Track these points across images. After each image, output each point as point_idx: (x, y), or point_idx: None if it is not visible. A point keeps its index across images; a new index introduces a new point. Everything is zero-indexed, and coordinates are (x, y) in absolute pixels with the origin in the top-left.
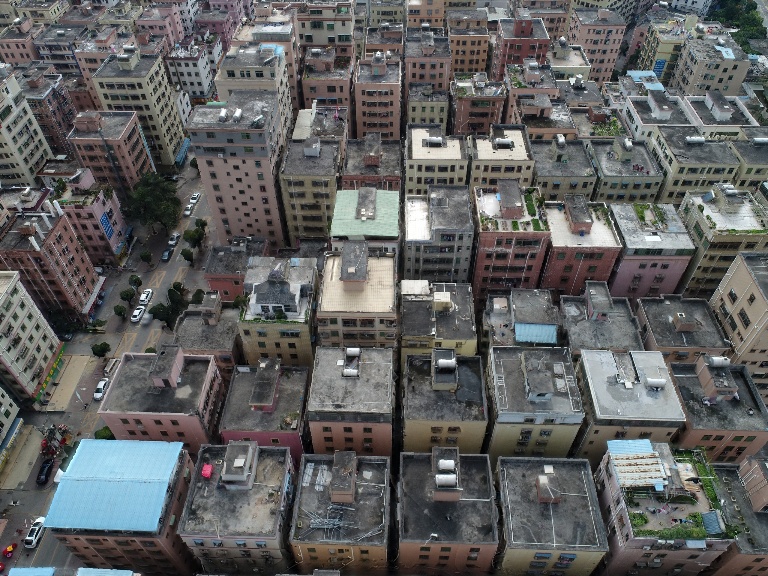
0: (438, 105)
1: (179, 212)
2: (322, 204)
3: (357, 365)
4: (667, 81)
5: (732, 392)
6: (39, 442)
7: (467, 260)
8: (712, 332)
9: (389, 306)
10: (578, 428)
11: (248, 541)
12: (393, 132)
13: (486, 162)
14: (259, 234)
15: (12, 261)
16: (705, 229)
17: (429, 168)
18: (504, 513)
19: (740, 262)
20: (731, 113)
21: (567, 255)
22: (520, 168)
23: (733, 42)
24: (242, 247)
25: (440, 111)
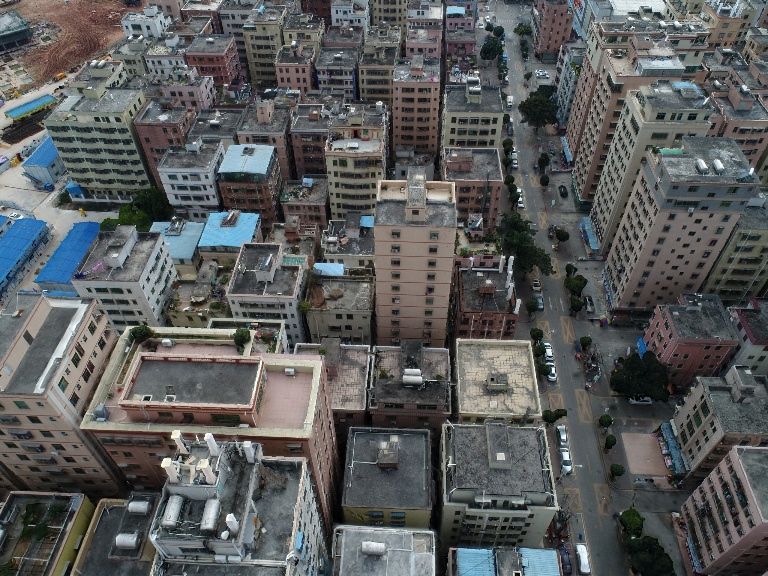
0: None
1: None
2: (765, 258)
3: None
4: None
5: None
6: None
7: None
8: None
9: None
10: None
11: None
12: None
13: None
14: (674, 287)
15: (480, 323)
16: None
17: None
18: None
19: None
20: None
21: None
22: None
23: None
24: (700, 307)
25: None
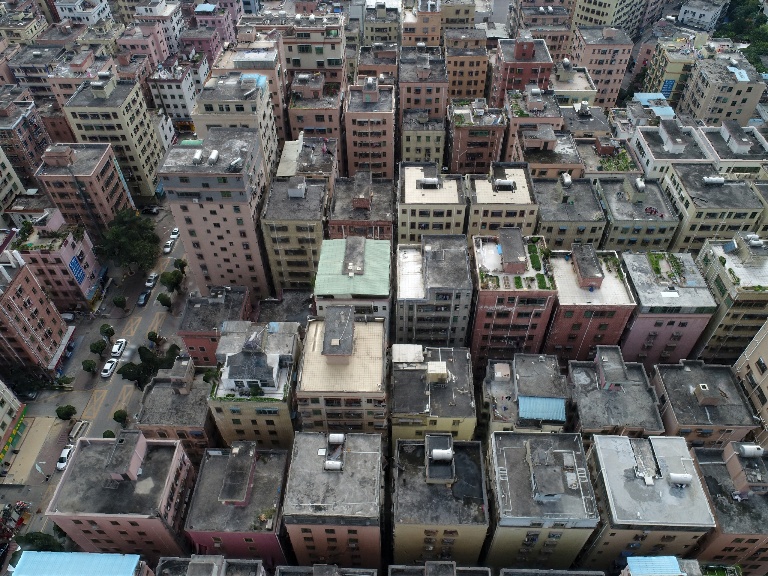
0: (434, 134)
1: (157, 251)
2: (308, 249)
3: (341, 454)
4: (676, 102)
5: (766, 487)
6: None
7: (465, 319)
8: (738, 405)
9: (377, 384)
10: (592, 531)
11: None
12: (386, 162)
13: (486, 207)
14: (241, 280)
15: None
16: (728, 285)
17: (423, 213)
18: None
19: None
20: (750, 146)
21: (575, 313)
22: (523, 213)
23: (746, 62)
24: (220, 299)
25: (436, 140)
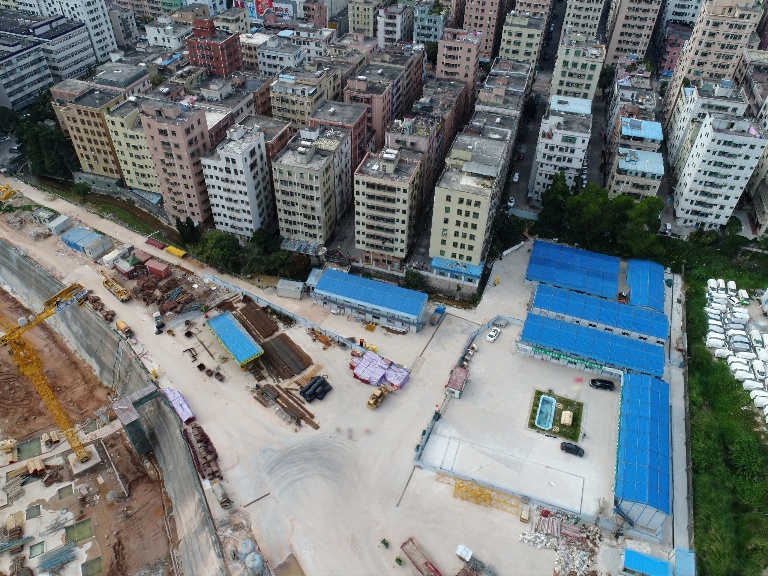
0: None
1: None
2: None
3: None
4: None
5: None
6: None
7: None
8: None
9: None
10: None
11: None
12: None
13: None
14: None
15: None
16: None
17: None
18: None
19: None
20: None
21: None
22: None
23: None
24: None
25: None
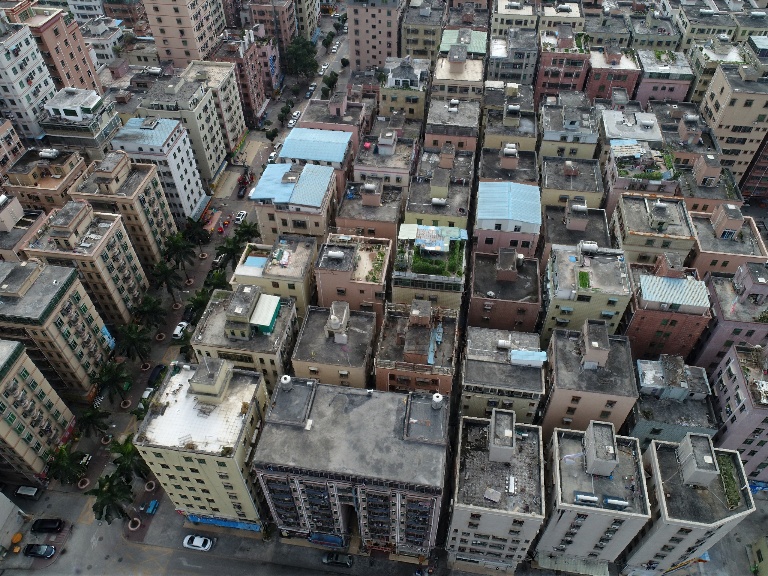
0: None
1: None
2: (429, 50)
3: None
4: None
5: (698, 135)
6: (236, 179)
7: (531, 77)
8: None
9: (479, 79)
10: (594, 148)
11: (392, 175)
12: None
13: (550, 18)
14: None
15: None
16: (701, 60)
17: (509, 22)
18: (543, 175)
19: (718, 70)
20: (742, 5)
21: (601, 76)
22: (574, 24)
23: None
24: (372, 72)
25: None
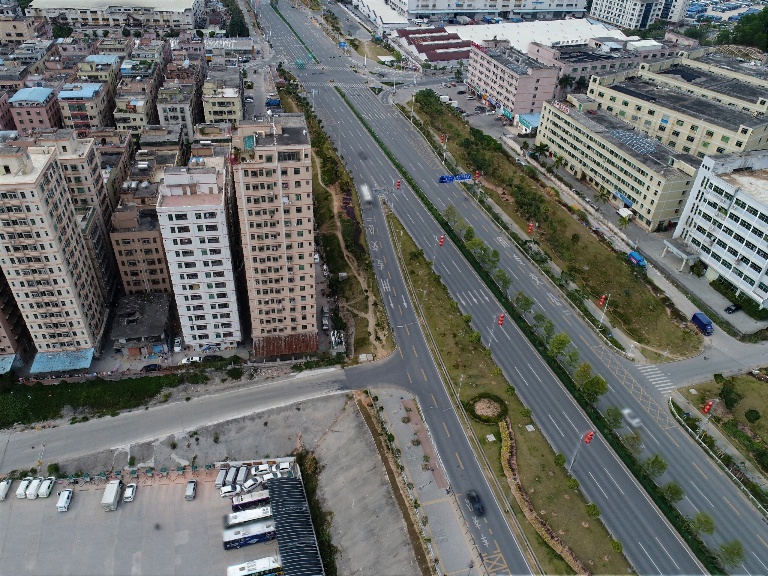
0: None
1: None
2: None
3: None
4: None
5: None
6: None
7: None
8: None
9: None
10: None
11: None
12: None
13: None
14: None
15: None
16: None
17: None
18: None
19: None
20: None
21: None
22: None
23: None
24: None
25: None
